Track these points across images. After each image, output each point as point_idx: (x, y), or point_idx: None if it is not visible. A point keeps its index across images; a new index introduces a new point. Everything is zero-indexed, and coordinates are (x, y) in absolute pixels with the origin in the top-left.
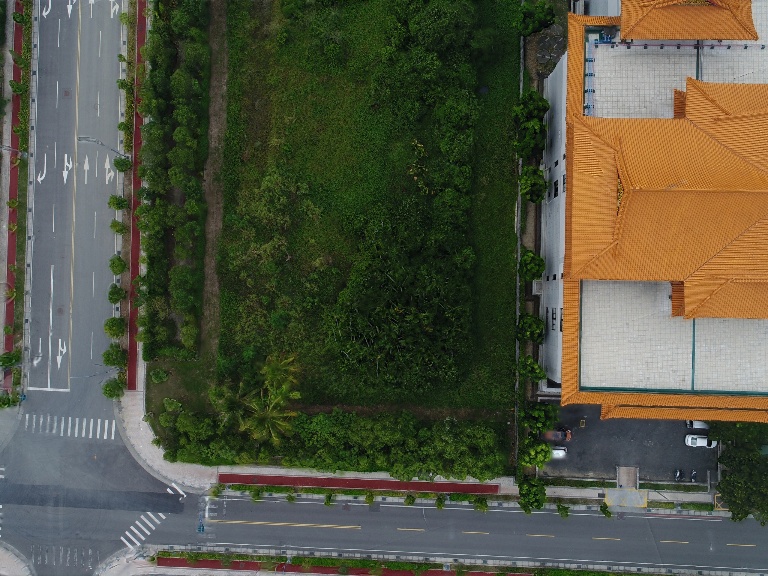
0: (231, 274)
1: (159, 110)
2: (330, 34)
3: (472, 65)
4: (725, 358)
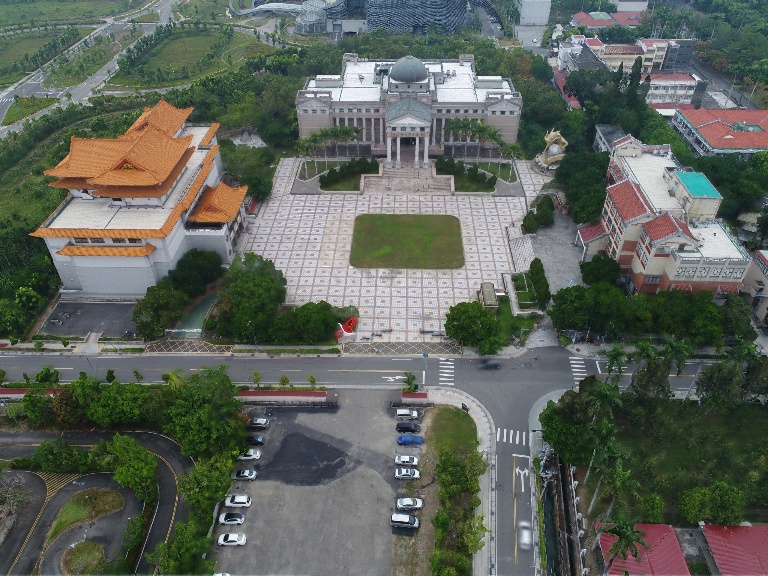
0: None
1: None
2: (38, 189)
3: None
4: None
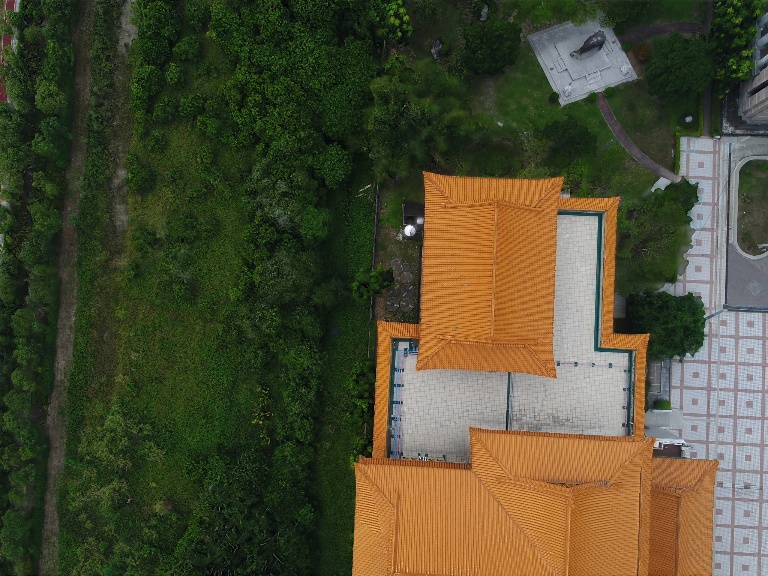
0: (70, 515)
1: (2, 345)
2: (178, 272)
3: (317, 315)
4: None
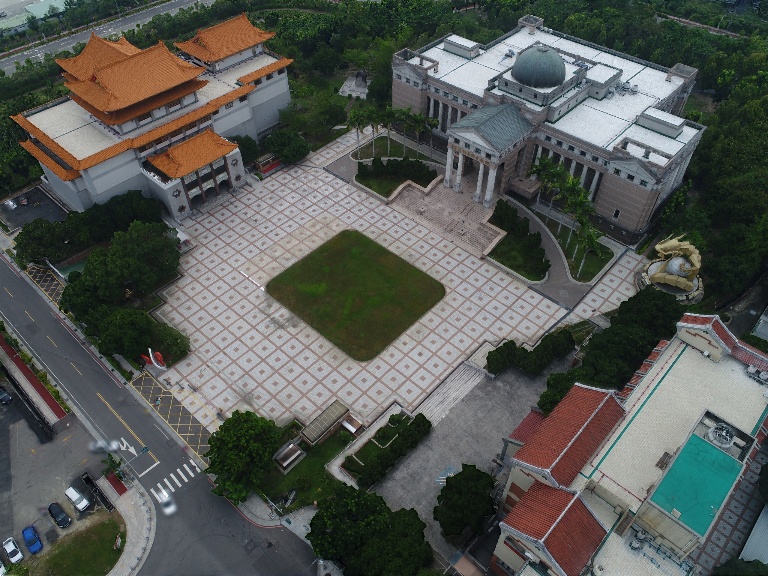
0: None
1: None
2: None
3: None
4: (77, 138)
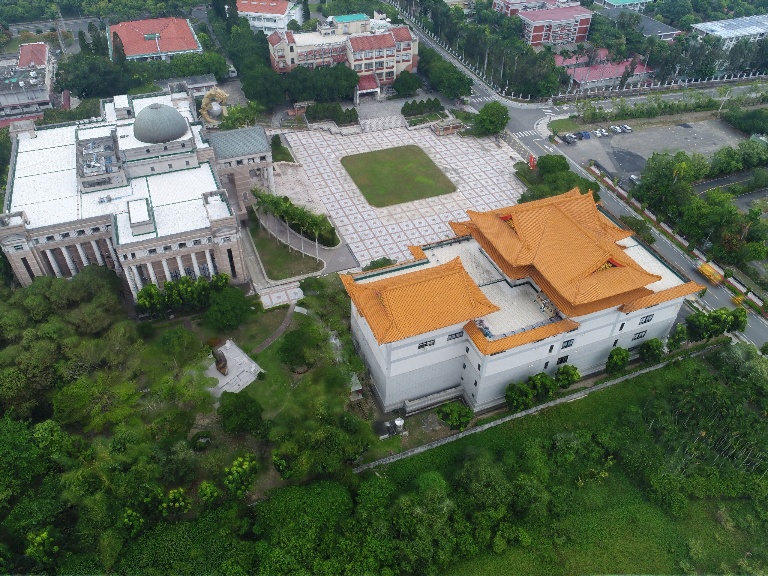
0: None
1: None
2: None
3: None
4: None
